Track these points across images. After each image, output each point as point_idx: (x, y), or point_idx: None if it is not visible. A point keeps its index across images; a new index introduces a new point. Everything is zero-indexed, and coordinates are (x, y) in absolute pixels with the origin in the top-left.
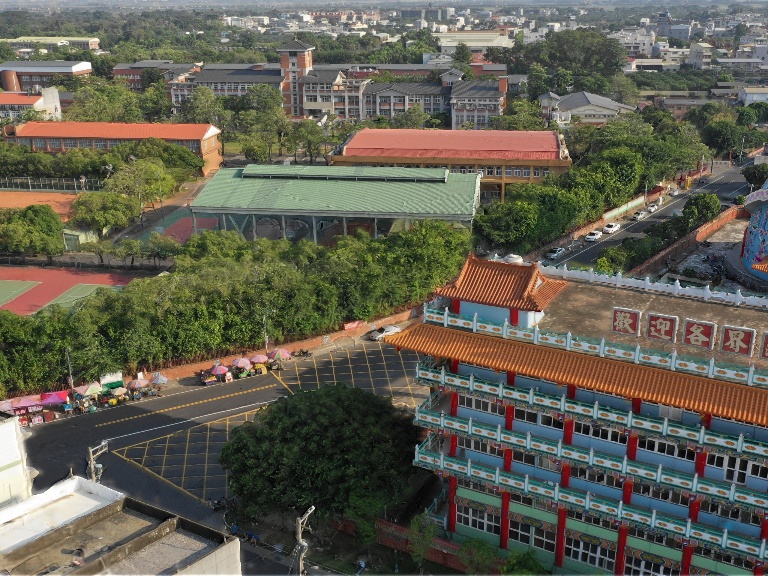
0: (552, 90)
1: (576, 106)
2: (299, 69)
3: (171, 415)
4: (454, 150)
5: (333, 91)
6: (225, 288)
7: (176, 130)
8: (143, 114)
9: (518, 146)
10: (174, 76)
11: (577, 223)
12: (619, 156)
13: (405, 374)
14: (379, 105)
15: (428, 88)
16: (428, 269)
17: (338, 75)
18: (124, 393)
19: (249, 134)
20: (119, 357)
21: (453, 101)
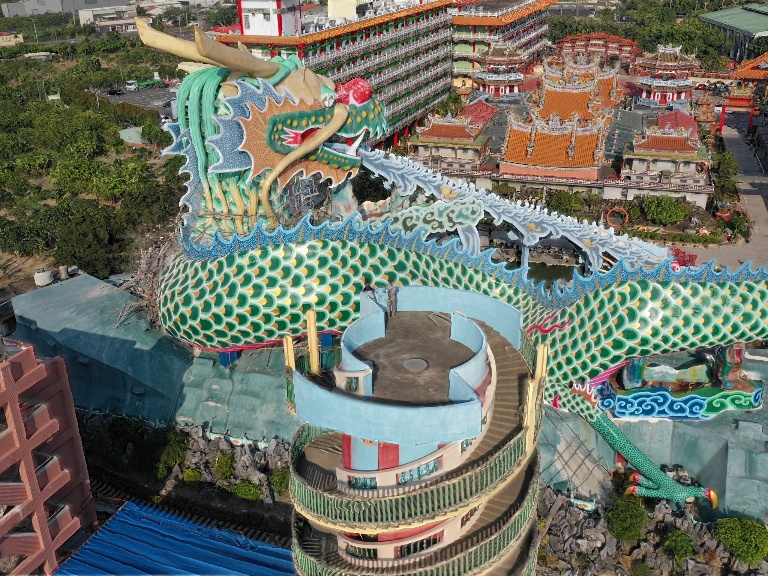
0: None
1: None
2: None
3: (541, 53)
4: None
5: None
6: (590, 22)
7: None
8: None
9: None
10: None
11: None
12: None
13: (599, 65)
14: None
15: None
16: (672, 41)
17: None
18: (546, 48)
19: None
20: (551, 35)
21: None
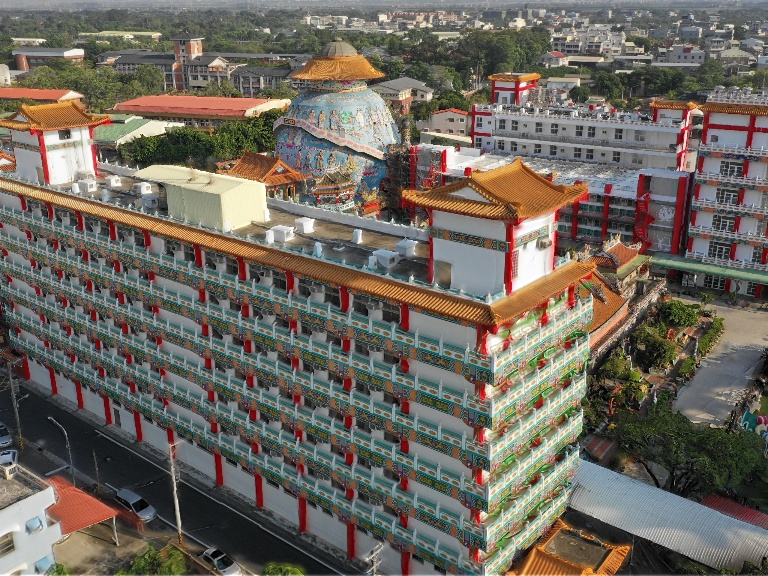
0: (387, 76)
1: (370, 86)
2: (187, 54)
3: None
4: (182, 108)
5: (209, 72)
6: None
7: (46, 93)
8: (51, 84)
9: (228, 106)
10: (104, 59)
11: (222, 157)
12: (271, 113)
13: None
14: (242, 84)
15: (279, 71)
16: None
17: (216, 60)
18: None
19: (105, 99)
20: None
21: (284, 81)
